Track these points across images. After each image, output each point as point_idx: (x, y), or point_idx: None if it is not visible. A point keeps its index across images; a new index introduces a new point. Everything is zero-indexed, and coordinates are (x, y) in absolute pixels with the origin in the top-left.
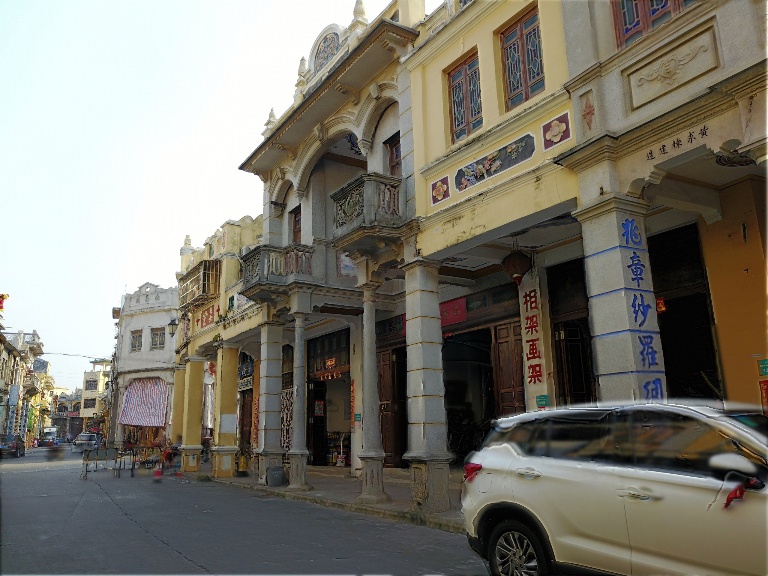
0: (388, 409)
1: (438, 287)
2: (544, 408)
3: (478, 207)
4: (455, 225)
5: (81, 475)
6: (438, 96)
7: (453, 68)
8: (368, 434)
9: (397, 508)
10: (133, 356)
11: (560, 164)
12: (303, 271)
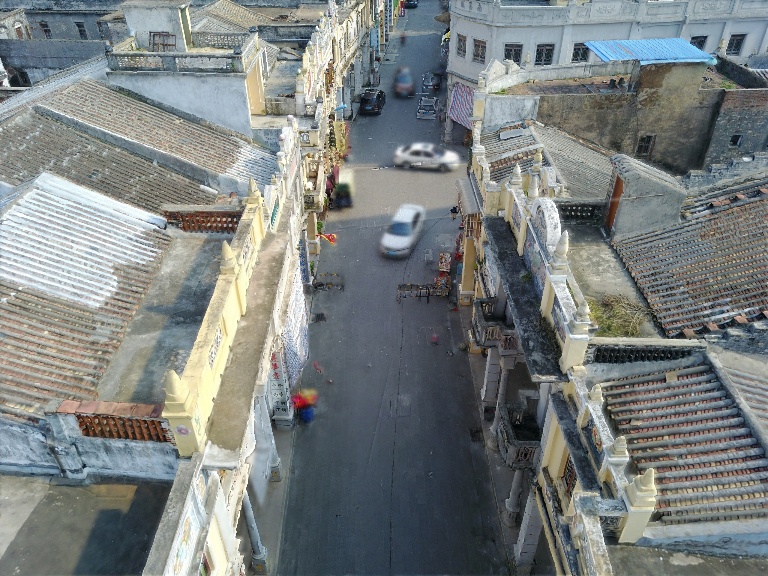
0: None
1: None
2: None
3: None
4: None
5: (397, 297)
6: (562, 445)
7: None
8: (511, 500)
9: None
10: (459, 61)
11: None
12: (510, 347)
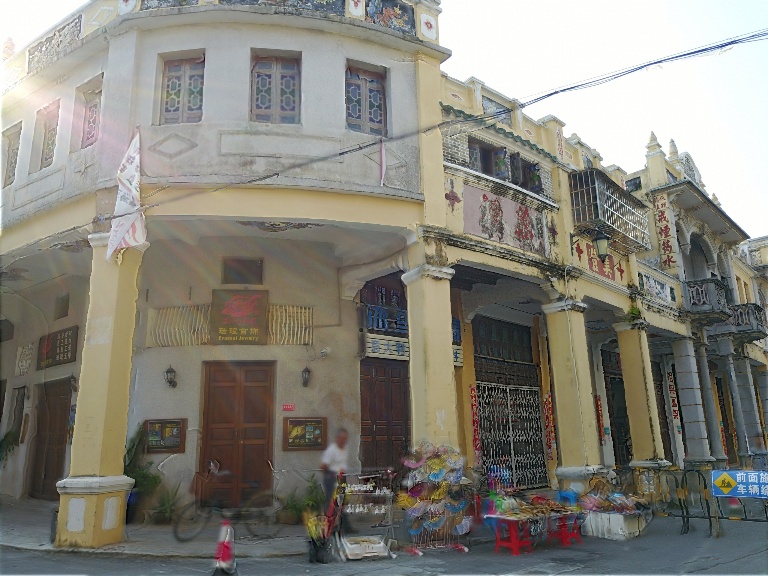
0: (611, 425)
1: None
2: None
3: None
4: None
5: None
6: None
7: None
8: None
9: None
10: None
11: (767, 352)
12: None
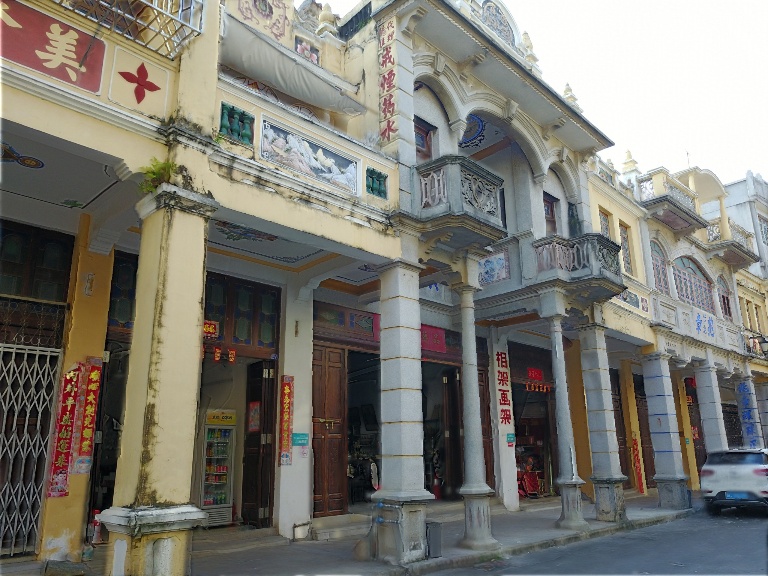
0: (336, 430)
1: (424, 307)
2: (513, 443)
3: (626, 317)
4: (619, 319)
5: None
6: None
7: (599, 209)
8: None
9: (602, 525)
10: None
11: None
12: None
